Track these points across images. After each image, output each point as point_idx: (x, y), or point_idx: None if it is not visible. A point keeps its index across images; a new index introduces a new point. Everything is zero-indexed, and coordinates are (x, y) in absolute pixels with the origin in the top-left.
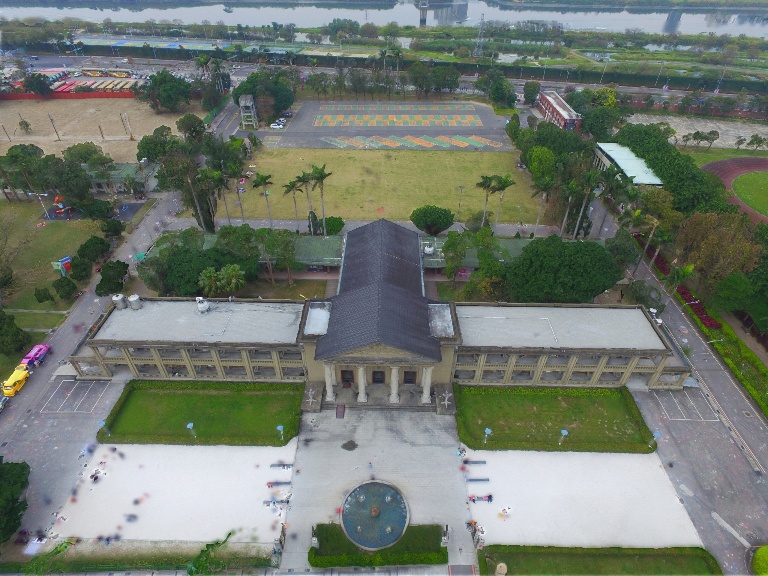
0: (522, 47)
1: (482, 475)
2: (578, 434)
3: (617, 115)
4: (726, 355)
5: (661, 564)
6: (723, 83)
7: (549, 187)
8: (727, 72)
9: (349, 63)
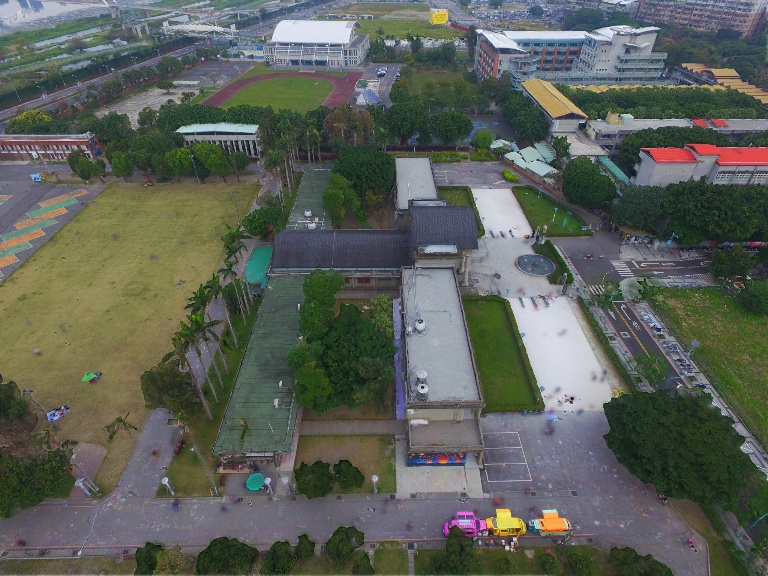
0: None
1: (498, 233)
2: None
3: None
4: None
5: (521, 198)
6: (64, 78)
7: None
8: (23, 74)
9: None
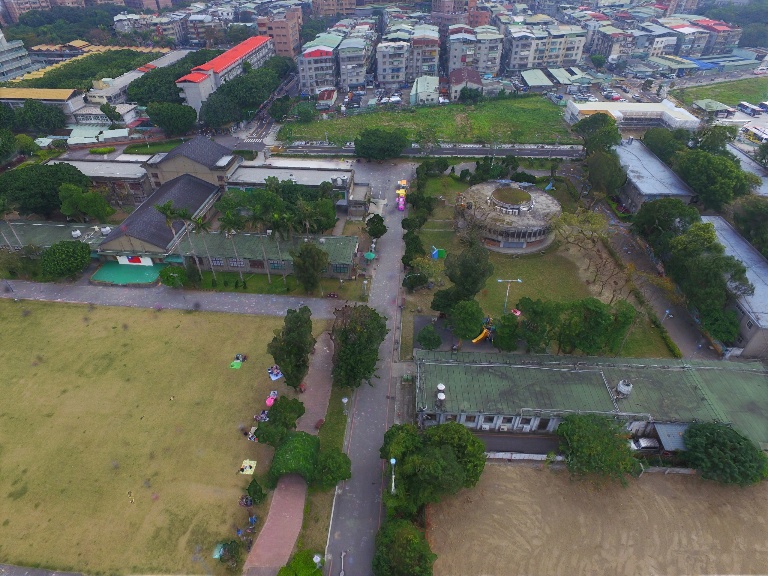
0: None
1: None
2: None
3: None
4: None
5: None
6: None
7: None
8: None
9: None
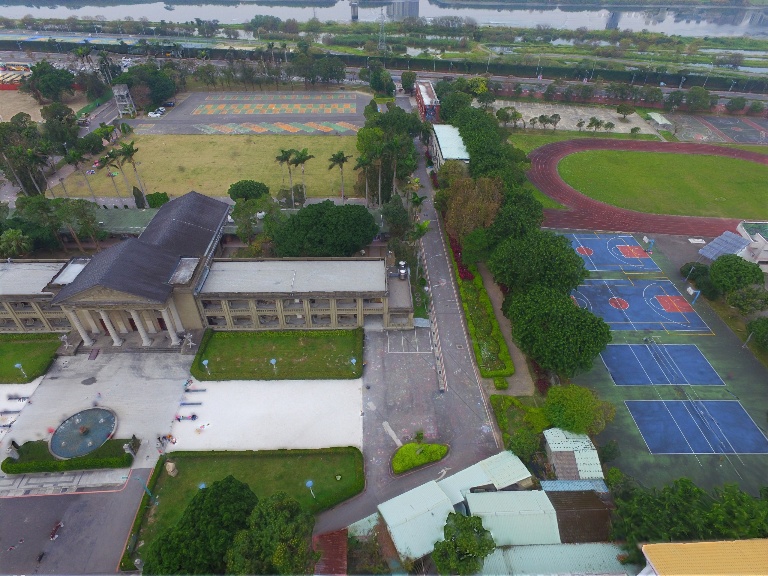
0: (432, 42)
1: (198, 400)
2: (301, 366)
3: (466, 100)
4: (466, 301)
5: (317, 461)
6: (596, 73)
7: (342, 159)
8: (612, 64)
9: (239, 55)
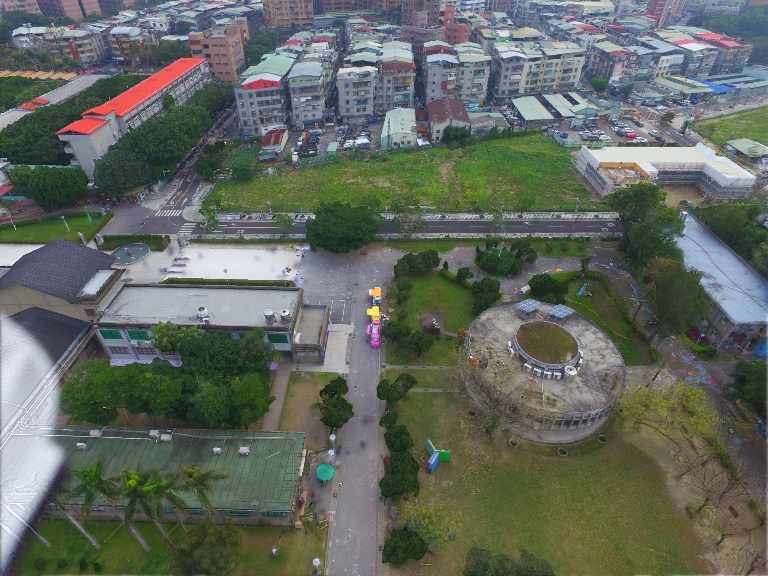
0: None
1: None
2: None
3: None
4: None
5: None
6: None
7: None
8: None
9: None
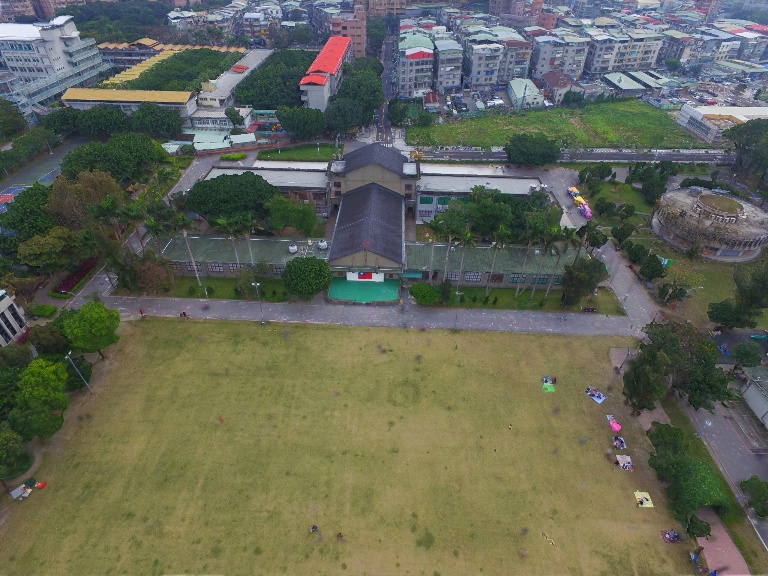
0: None
1: None
2: None
3: None
4: None
5: None
6: None
7: None
8: None
9: None
